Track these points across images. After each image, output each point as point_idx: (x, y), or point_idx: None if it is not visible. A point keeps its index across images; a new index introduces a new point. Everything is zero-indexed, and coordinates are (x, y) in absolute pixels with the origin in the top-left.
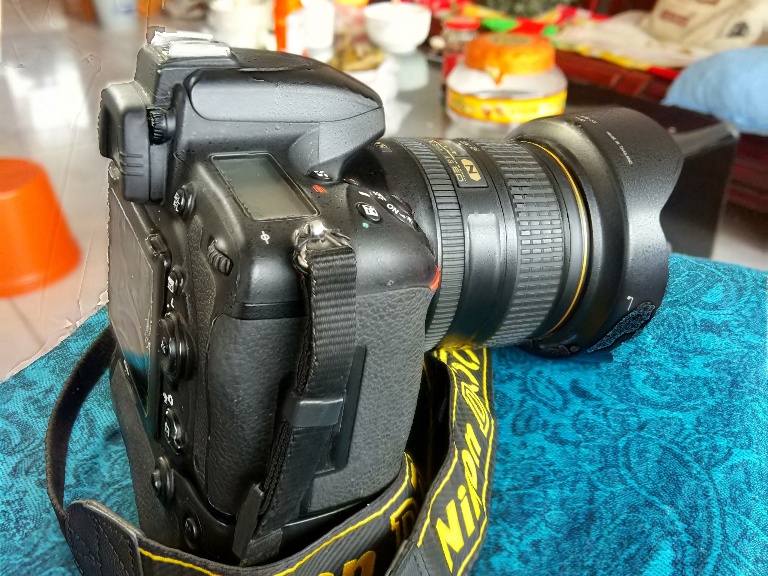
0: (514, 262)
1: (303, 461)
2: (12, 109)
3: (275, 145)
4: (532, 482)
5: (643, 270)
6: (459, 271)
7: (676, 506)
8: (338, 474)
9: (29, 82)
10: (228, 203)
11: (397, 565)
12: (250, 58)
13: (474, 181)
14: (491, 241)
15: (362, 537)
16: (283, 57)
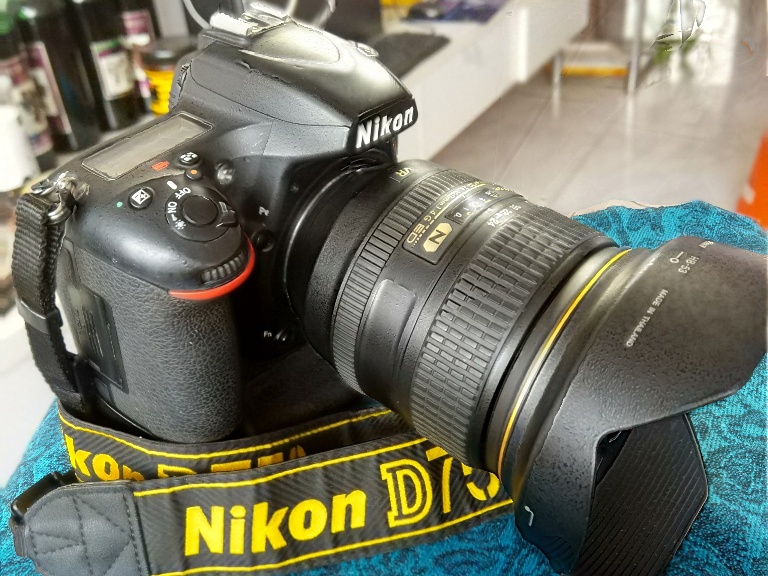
0: (413, 360)
1: (41, 346)
2: (503, 50)
3: (227, 123)
4: None
5: (547, 488)
6: (353, 328)
7: None
8: (125, 395)
9: (529, 30)
10: None
11: (100, 484)
12: (271, 43)
13: (423, 250)
14: (397, 321)
15: (134, 457)
16: (307, 50)
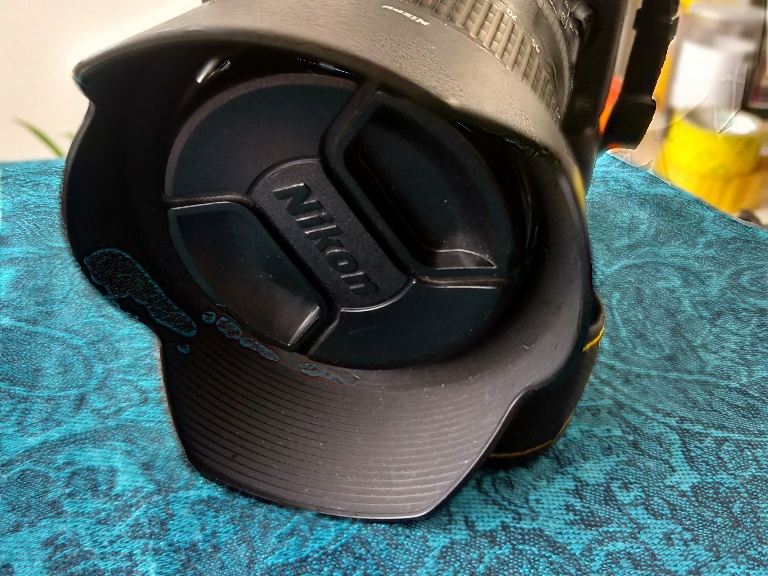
0: None
1: None
2: None
3: None
4: None
5: None
6: None
7: (6, 330)
8: None
9: None
10: None
11: None
12: None
13: None
14: None
15: None
16: None
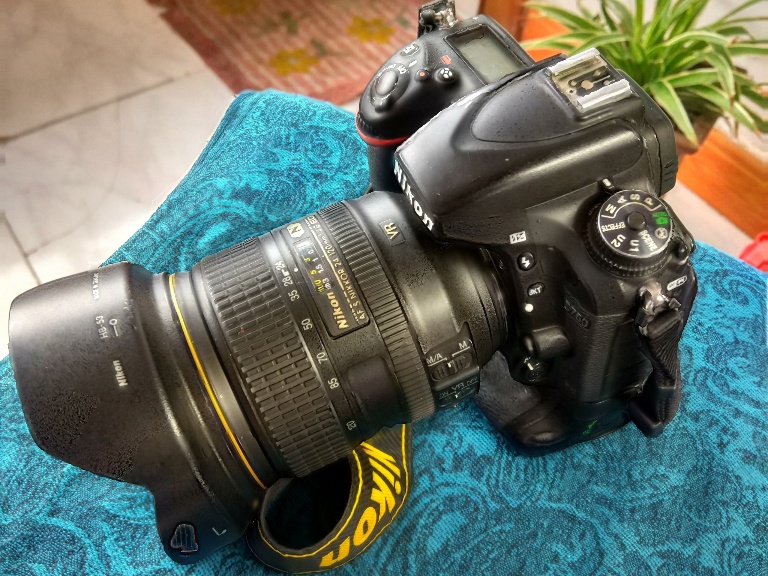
0: None
1: None
2: None
3: None
4: None
5: None
6: None
7: None
8: None
9: None
10: (505, 33)
11: None
12: (528, 90)
13: None
14: None
15: None
16: (499, 113)
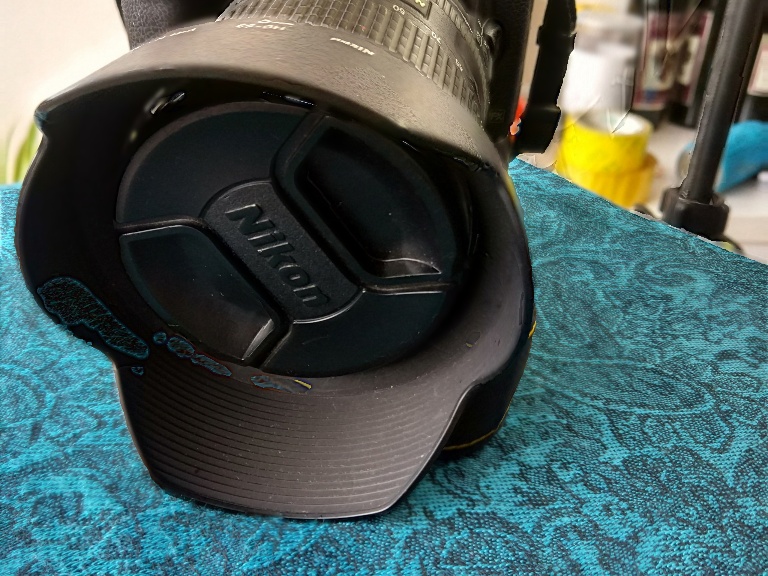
0: None
1: None
2: None
3: None
4: (116, 321)
5: None
6: None
7: None
8: None
9: None
10: None
11: None
12: None
13: None
14: None
15: None
16: None
